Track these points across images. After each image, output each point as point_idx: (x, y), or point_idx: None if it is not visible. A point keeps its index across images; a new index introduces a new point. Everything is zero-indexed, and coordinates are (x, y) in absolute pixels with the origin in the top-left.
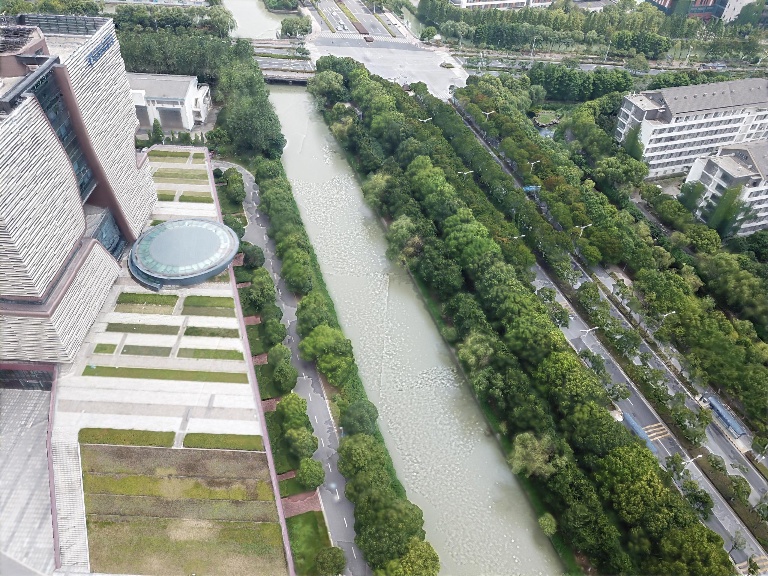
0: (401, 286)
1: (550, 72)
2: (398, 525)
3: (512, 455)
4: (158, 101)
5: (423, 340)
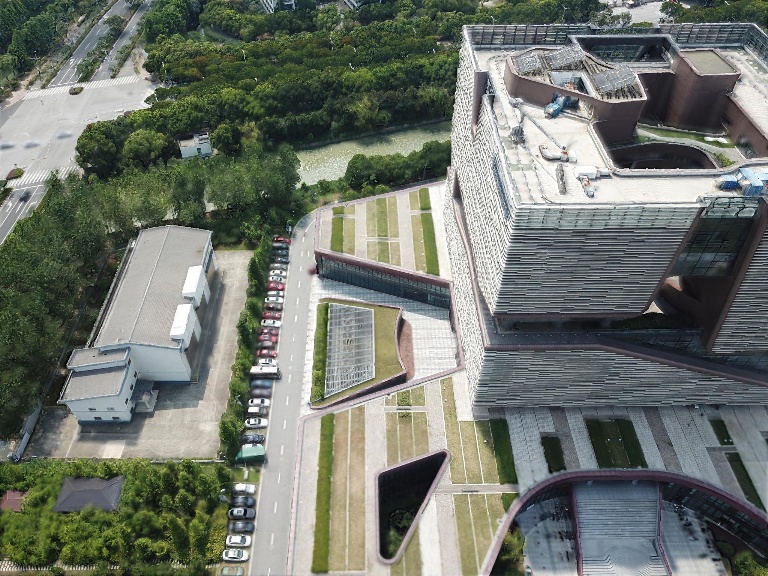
0: None
1: (167, 20)
2: None
3: None
4: (203, 263)
5: None
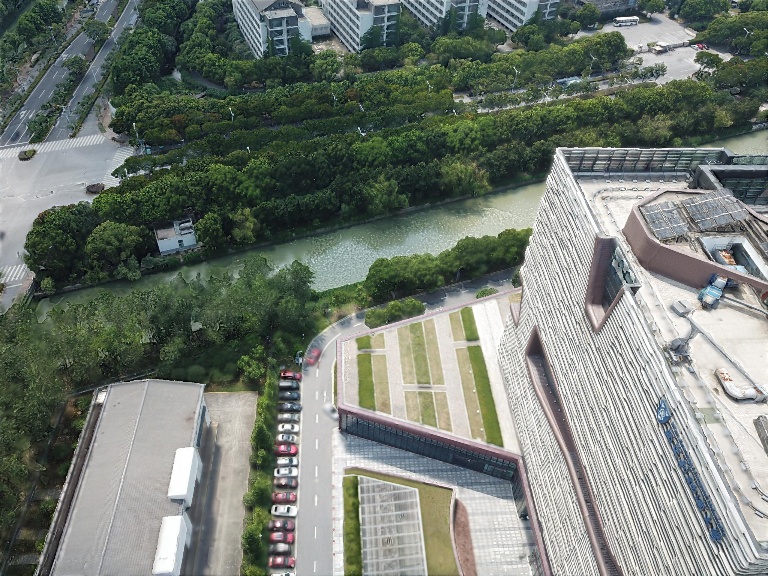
0: (494, 201)
1: (138, 66)
2: None
3: None
4: None
5: None
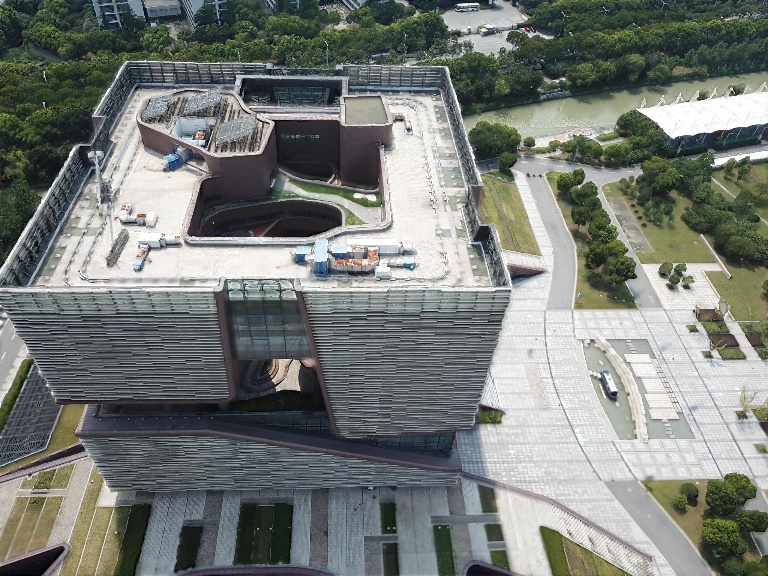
0: None
1: None
2: (492, 125)
3: None
4: None
5: None
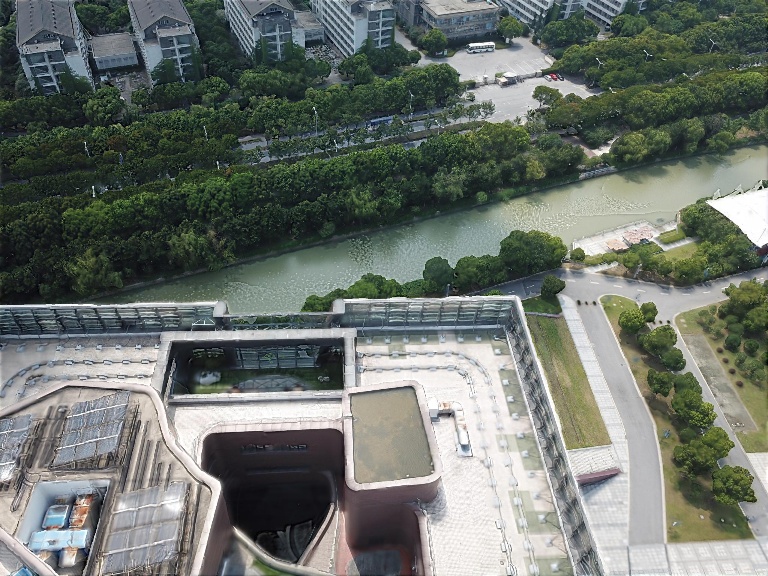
0: (245, 273)
1: None
2: (531, 237)
3: (432, 211)
4: None
5: (314, 262)
